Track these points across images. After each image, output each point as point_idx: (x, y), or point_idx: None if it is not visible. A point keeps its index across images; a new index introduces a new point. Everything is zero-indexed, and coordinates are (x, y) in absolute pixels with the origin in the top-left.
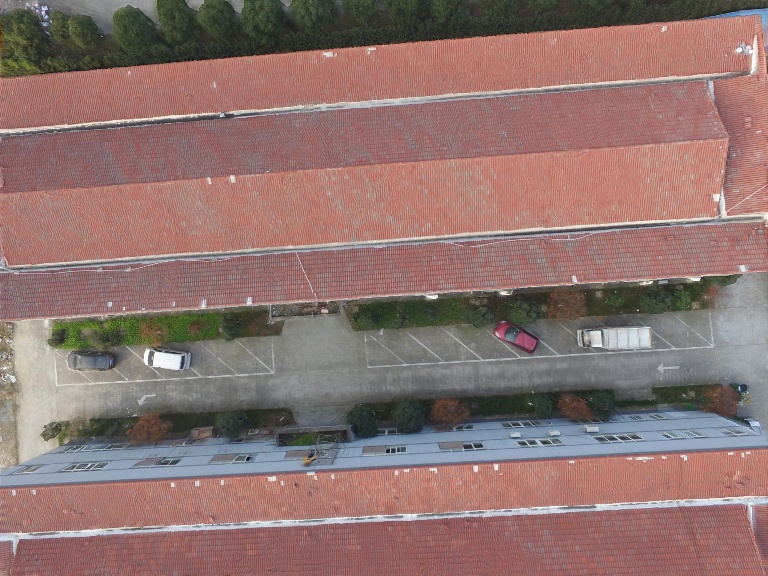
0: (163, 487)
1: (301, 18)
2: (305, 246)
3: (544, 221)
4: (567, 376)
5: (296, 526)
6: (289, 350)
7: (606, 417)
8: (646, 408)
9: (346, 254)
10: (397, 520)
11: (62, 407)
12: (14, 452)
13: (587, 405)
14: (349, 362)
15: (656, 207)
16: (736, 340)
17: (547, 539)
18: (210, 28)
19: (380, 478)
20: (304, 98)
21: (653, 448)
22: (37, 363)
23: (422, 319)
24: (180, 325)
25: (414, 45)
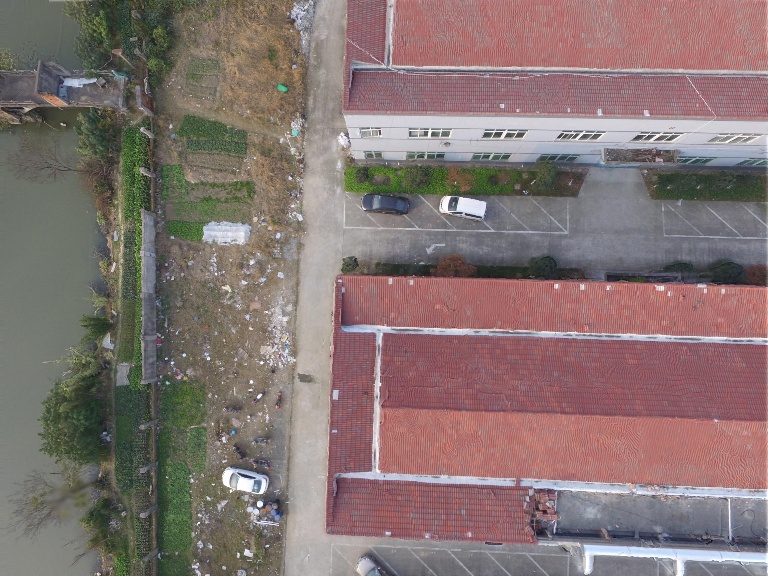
0: (546, 288)
1: None
2: (694, 71)
3: None
4: None
5: (673, 342)
6: (585, 212)
7: None
8: None
9: (738, 81)
10: None
11: (348, 249)
12: (294, 289)
13: None
14: (645, 229)
15: None
16: None
17: None
18: None
19: None
20: None
21: None
22: (326, 204)
23: (722, 193)
24: (477, 178)
25: None
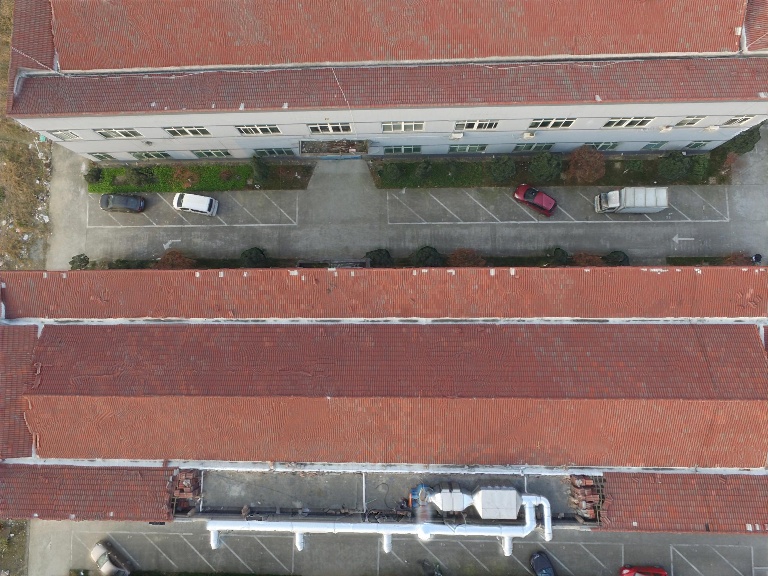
0: (188, 276)
1: None
2: (341, 63)
3: (571, 48)
4: (583, 242)
5: (313, 324)
6: (313, 204)
7: None
8: None
9: (379, 71)
10: (412, 323)
11: (90, 248)
12: None
13: (602, 259)
14: (370, 218)
15: (679, 38)
16: (751, 215)
17: (559, 345)
18: None
19: (398, 277)
20: None
21: None
22: (71, 205)
23: (444, 180)
24: (210, 175)
25: None
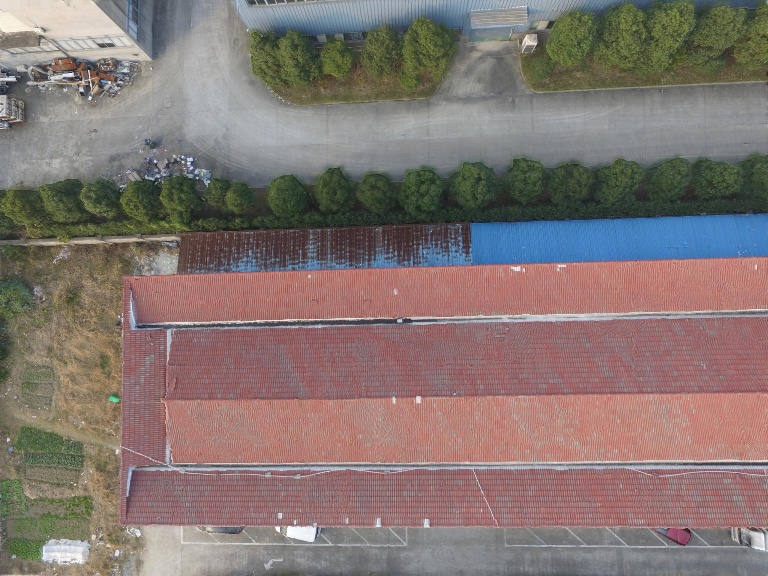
0: None
1: (464, 201)
2: (482, 463)
3: (739, 454)
4: (718, 569)
5: None
6: None
7: None
8: None
9: (526, 475)
10: None
11: (186, 566)
12: None
13: None
14: (486, 539)
15: None
16: None
17: None
18: (370, 205)
19: None
20: (488, 311)
21: None
22: None
23: None
24: None
25: (608, 266)
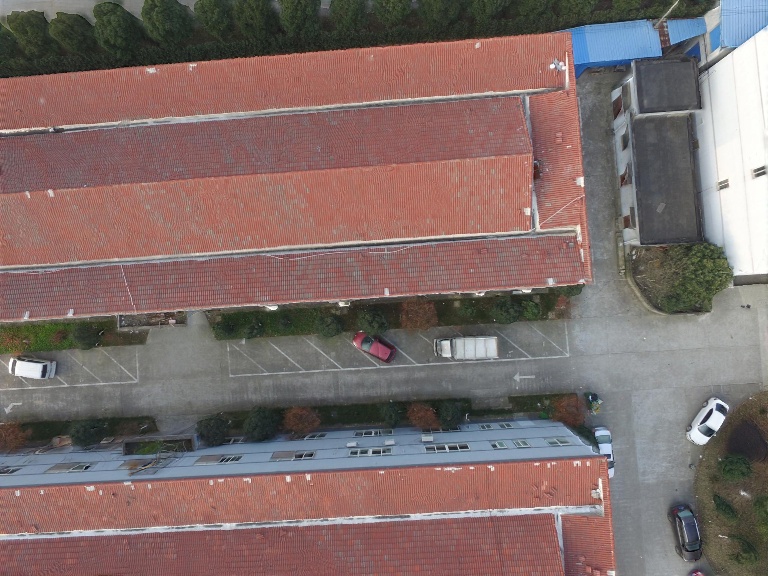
0: None
1: (150, 33)
2: (130, 258)
3: (362, 234)
4: (425, 385)
5: (117, 535)
6: (153, 359)
7: (447, 426)
8: (502, 417)
9: (169, 266)
10: (216, 529)
11: None
12: None
13: (435, 414)
14: (212, 371)
15: (470, 221)
16: (591, 350)
17: (358, 548)
18: (63, 42)
19: (196, 488)
20: (129, 113)
21: (467, 458)
22: None
23: None
24: (46, 334)
25: (233, 61)
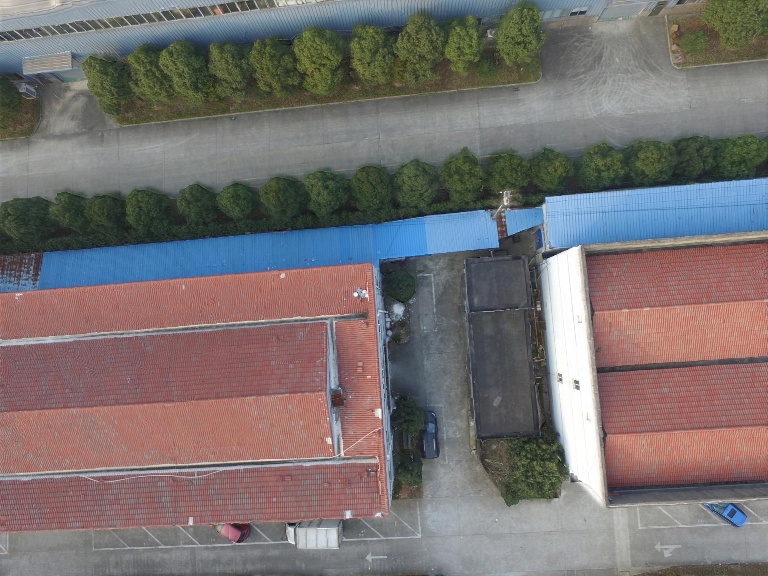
0: None
1: (9, 234)
2: None
3: (173, 458)
4: (279, 563)
5: None
6: None
7: None
8: None
9: None
10: None
11: None
12: None
13: None
14: (76, 544)
15: (274, 448)
16: (443, 530)
17: None
18: None
19: None
20: None
21: None
22: None
23: None
24: None
25: (53, 293)
